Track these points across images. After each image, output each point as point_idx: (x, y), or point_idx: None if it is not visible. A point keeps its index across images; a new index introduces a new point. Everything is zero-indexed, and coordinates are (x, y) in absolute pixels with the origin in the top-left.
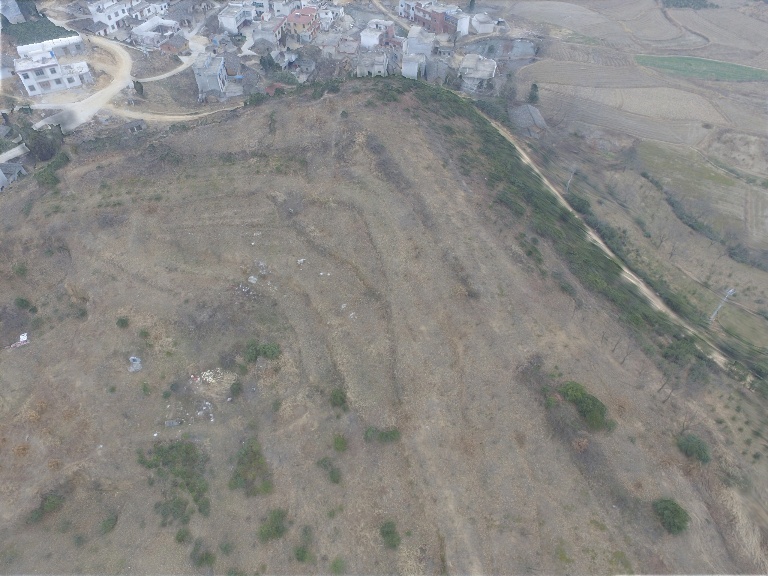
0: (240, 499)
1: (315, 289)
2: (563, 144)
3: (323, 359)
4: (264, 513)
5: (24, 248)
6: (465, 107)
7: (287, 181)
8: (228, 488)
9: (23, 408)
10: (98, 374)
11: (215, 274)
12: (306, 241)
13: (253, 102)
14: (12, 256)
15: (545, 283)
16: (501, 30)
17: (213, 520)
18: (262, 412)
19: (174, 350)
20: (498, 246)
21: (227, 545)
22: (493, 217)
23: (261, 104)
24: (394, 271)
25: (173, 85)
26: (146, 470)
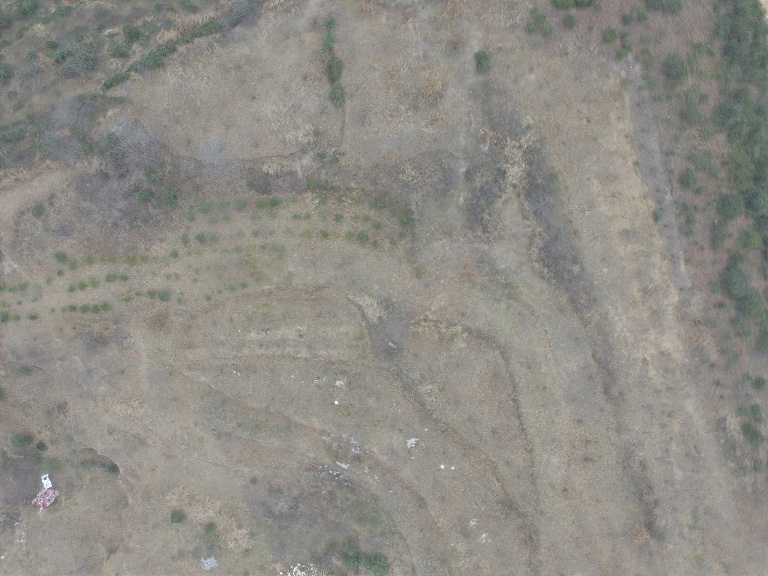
0: None
1: (434, 493)
2: None
3: None
4: None
5: None
6: None
7: (380, 265)
8: None
9: None
10: (168, 574)
11: (287, 447)
12: (418, 402)
13: None
14: None
15: (755, 490)
16: None
17: None
18: None
19: (252, 544)
20: (707, 423)
21: None
22: (713, 354)
23: None
24: (549, 480)
25: None
26: None
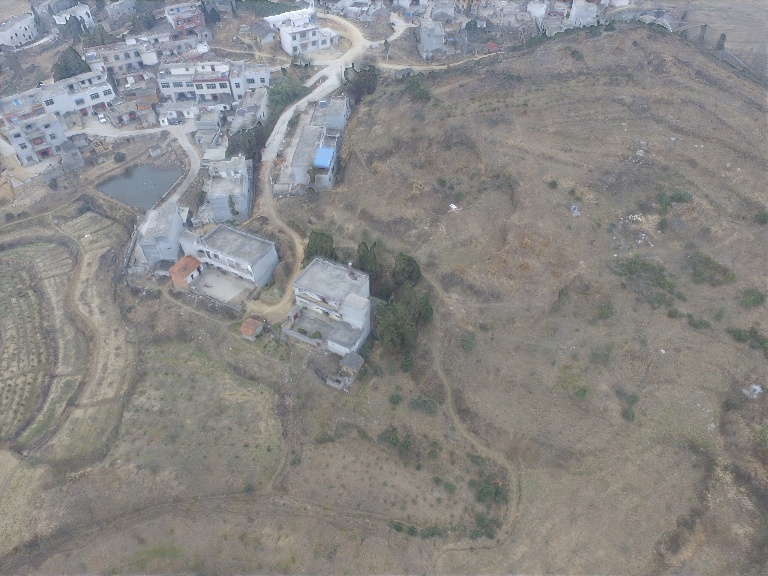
0: (709, 289)
1: (698, 155)
2: (763, 80)
3: (733, 198)
4: (735, 294)
5: (429, 144)
6: None
7: (624, 89)
8: (694, 284)
9: (510, 240)
10: (552, 218)
11: (605, 151)
12: (668, 126)
13: (533, 43)
14: (418, 151)
15: None
16: (636, 3)
17: (694, 303)
18: (693, 237)
19: (599, 202)
20: None
21: (716, 315)
22: None
23: (541, 44)
24: (758, 140)
25: (399, 47)
26: (620, 278)
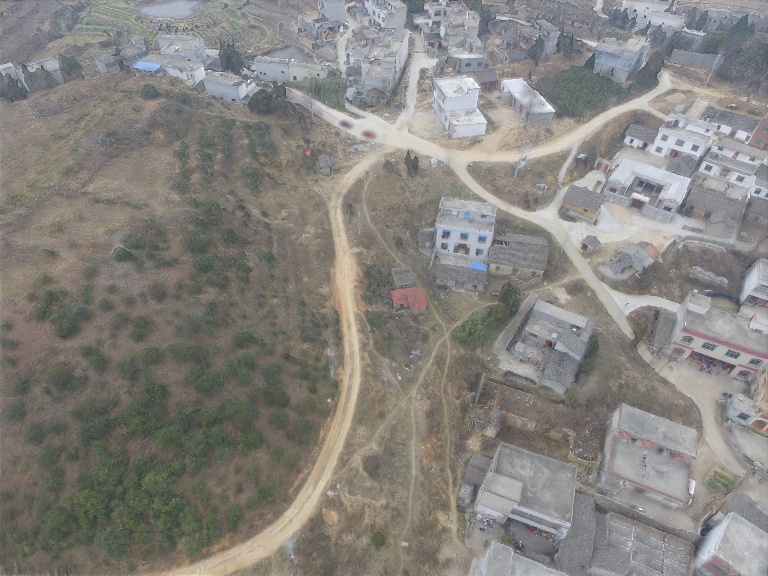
0: None
1: None
2: None
3: None
4: None
5: None
6: (70, 502)
7: None
8: None
9: None
10: None
11: None
12: None
13: None
14: None
15: None
16: None
17: None
18: None
19: None
20: None
21: None
22: None
23: None
24: None
25: None
26: None
